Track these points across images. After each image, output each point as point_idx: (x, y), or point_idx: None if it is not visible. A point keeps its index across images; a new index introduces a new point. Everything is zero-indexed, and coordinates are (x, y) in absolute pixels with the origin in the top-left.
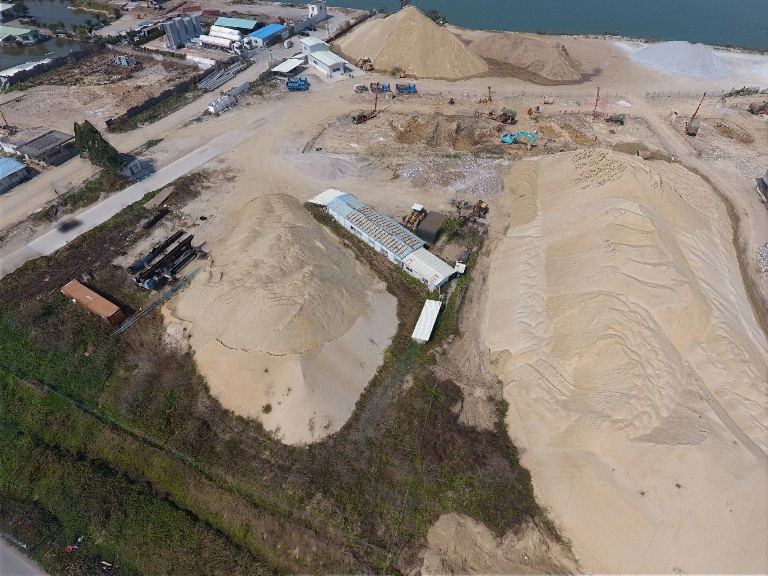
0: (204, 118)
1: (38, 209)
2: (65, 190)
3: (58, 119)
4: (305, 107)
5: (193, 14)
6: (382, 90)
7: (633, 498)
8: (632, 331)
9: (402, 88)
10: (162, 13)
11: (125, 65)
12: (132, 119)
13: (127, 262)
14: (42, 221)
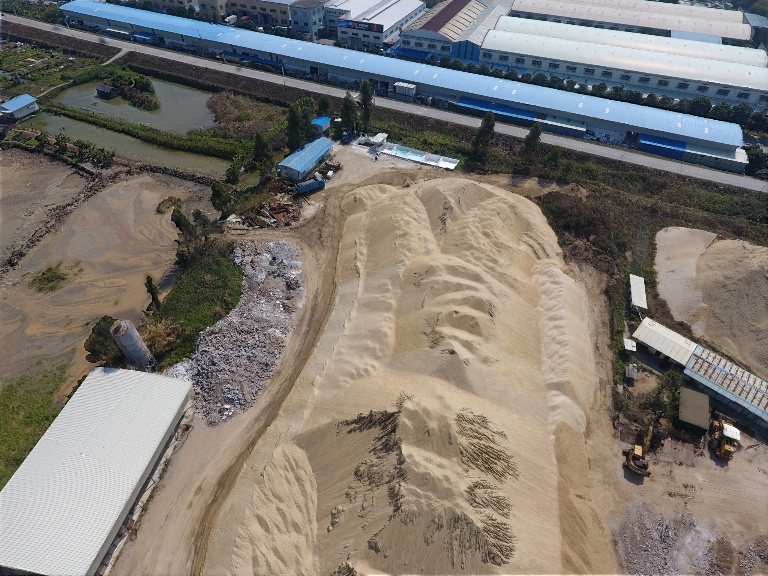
0: None
1: None
2: None
3: None
4: None
5: None
6: None
7: (498, 188)
8: (484, 245)
9: None
10: None
11: None
12: None
13: None
14: None
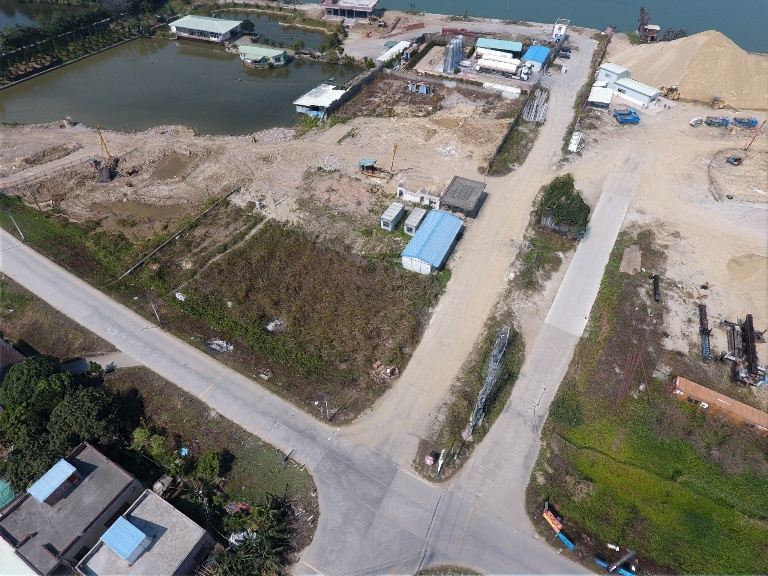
0: (569, 158)
1: (510, 274)
2: (516, 249)
3: (418, 159)
4: (658, 144)
5: (459, 35)
6: (721, 124)
7: None
8: None
9: (744, 122)
10: (387, 31)
11: (422, 93)
12: (503, 160)
13: (681, 346)
14: (529, 290)
